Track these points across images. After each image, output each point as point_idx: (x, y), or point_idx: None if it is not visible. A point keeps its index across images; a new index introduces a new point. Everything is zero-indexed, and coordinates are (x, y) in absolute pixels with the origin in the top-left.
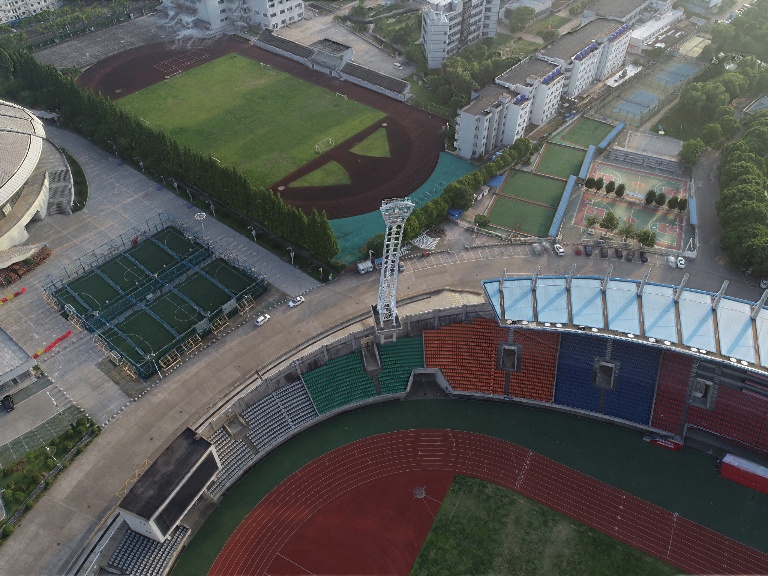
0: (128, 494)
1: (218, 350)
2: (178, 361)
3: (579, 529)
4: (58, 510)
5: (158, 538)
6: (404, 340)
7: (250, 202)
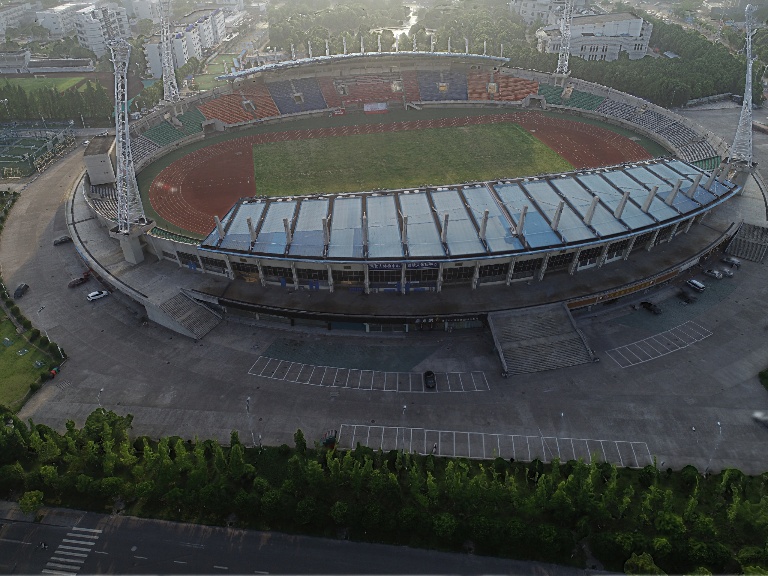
0: (85, 153)
1: (69, 158)
2: (45, 167)
3: (319, 139)
4: (26, 216)
5: (113, 176)
6: (188, 113)
7: (28, 106)
